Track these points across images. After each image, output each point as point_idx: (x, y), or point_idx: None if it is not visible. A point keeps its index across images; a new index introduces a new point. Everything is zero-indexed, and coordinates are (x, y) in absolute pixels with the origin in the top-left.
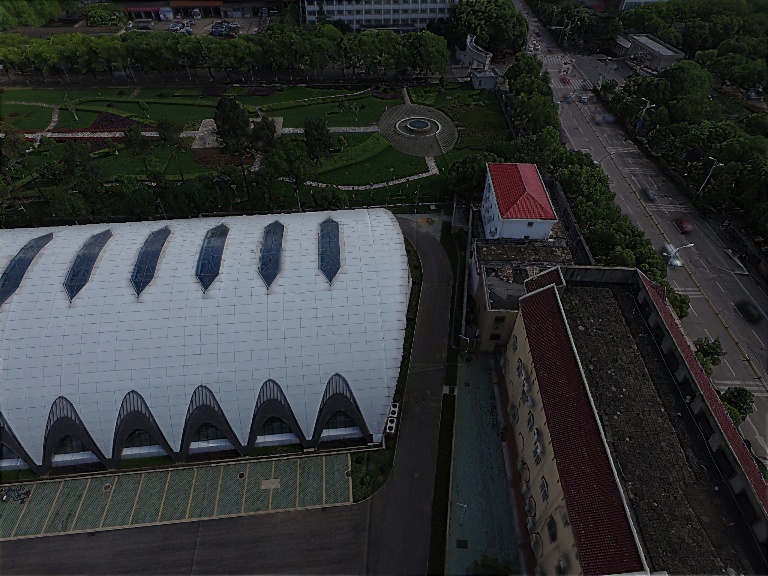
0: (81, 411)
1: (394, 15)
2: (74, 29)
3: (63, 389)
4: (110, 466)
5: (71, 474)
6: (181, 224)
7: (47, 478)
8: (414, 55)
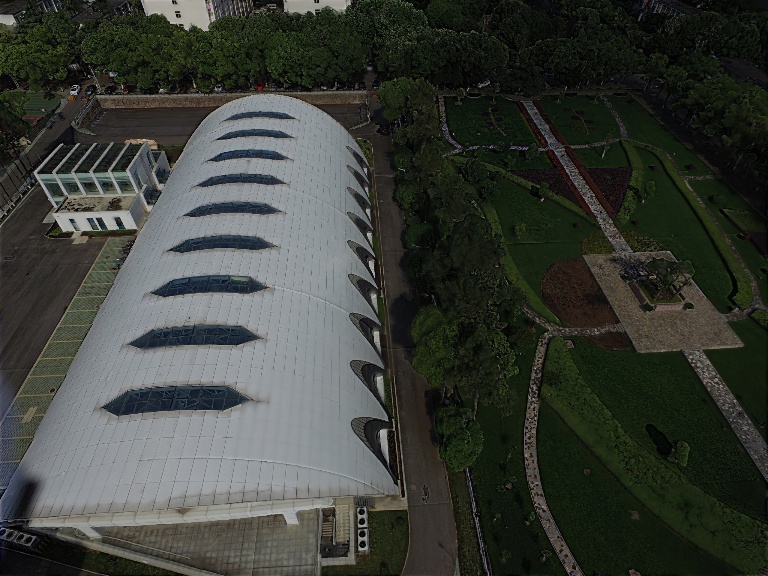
0: None
1: None
2: None
3: None
4: None
5: None
6: (282, 257)
7: None
8: None
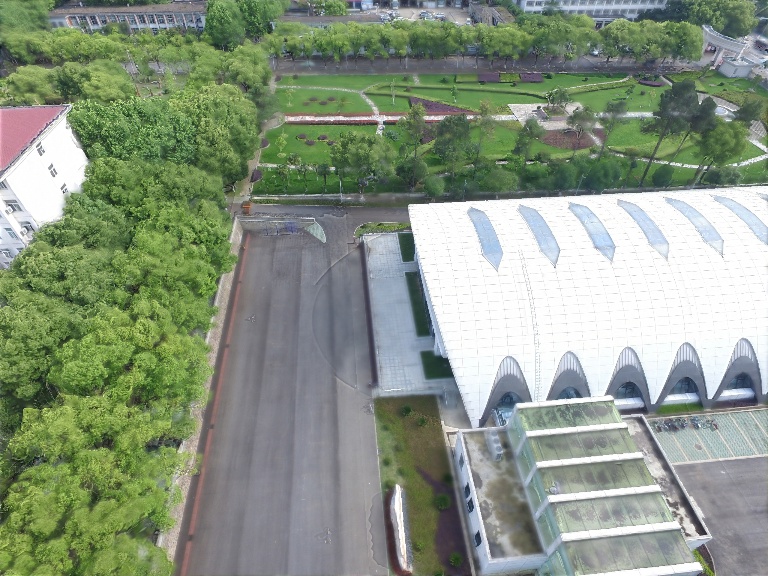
0: (758, 351)
1: (607, 6)
2: (339, 18)
3: (745, 332)
4: (760, 401)
5: (728, 408)
6: None
7: (711, 411)
8: (677, 44)
